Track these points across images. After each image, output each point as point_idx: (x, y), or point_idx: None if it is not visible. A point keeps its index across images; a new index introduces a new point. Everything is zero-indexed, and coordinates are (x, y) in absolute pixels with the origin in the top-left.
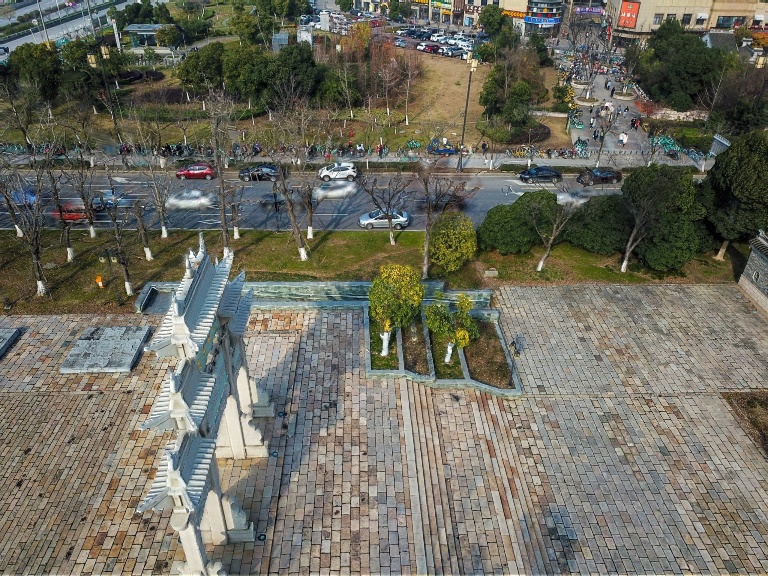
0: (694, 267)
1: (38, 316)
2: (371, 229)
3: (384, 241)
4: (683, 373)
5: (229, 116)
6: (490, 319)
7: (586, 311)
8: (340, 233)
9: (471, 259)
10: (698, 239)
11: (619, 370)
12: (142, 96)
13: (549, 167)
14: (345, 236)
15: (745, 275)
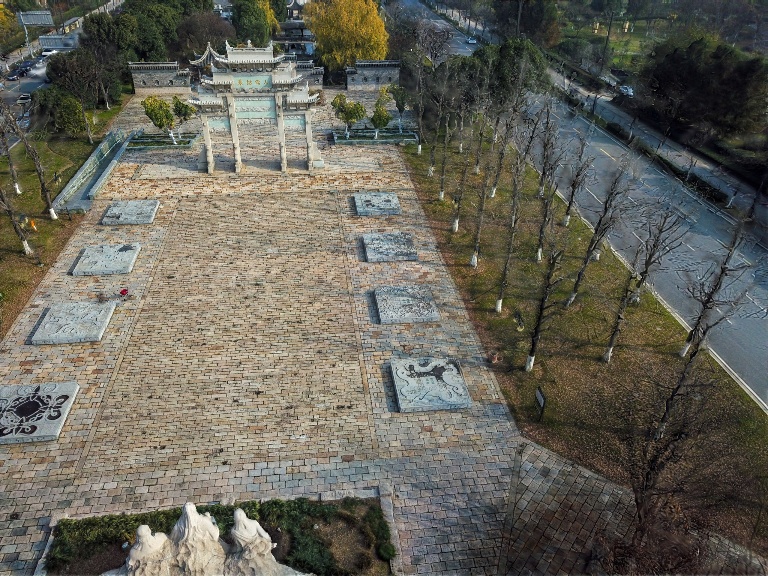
0: None
1: (65, 249)
2: None
3: None
4: None
5: None
6: (144, 132)
7: None
8: None
9: None
10: None
11: None
12: None
13: None
14: (0, 168)
15: (137, 87)
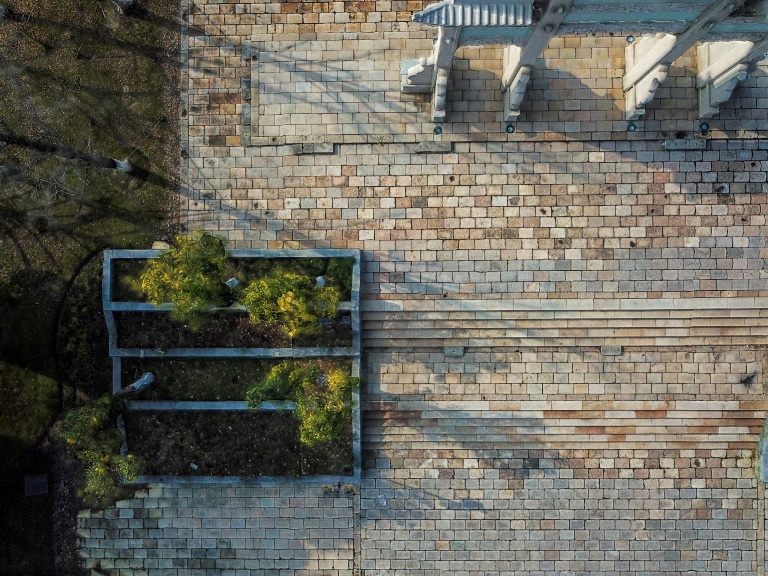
0: None
1: None
2: None
3: None
4: None
5: None
6: None
7: None
8: None
9: None
10: None
11: None
12: None
13: None
14: None
15: None
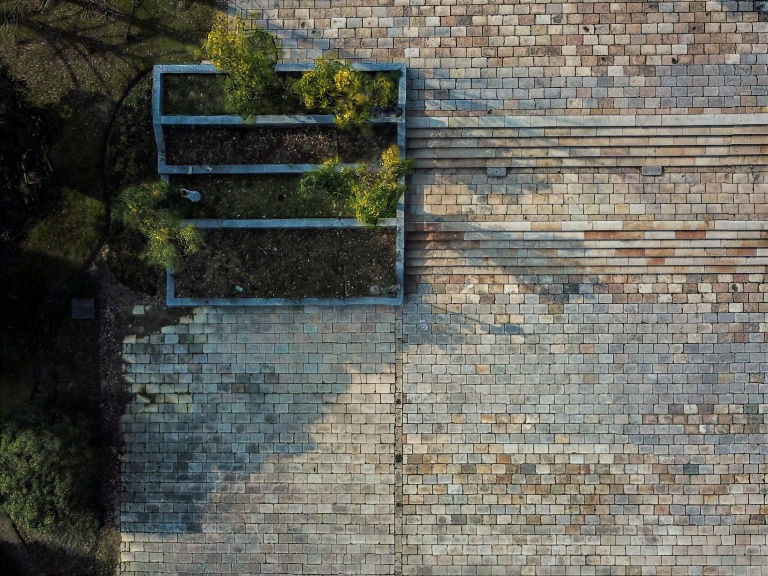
0: None
1: None
2: None
3: None
4: None
5: None
6: None
7: None
8: None
9: None
10: None
11: None
12: None
13: None
14: None
15: None
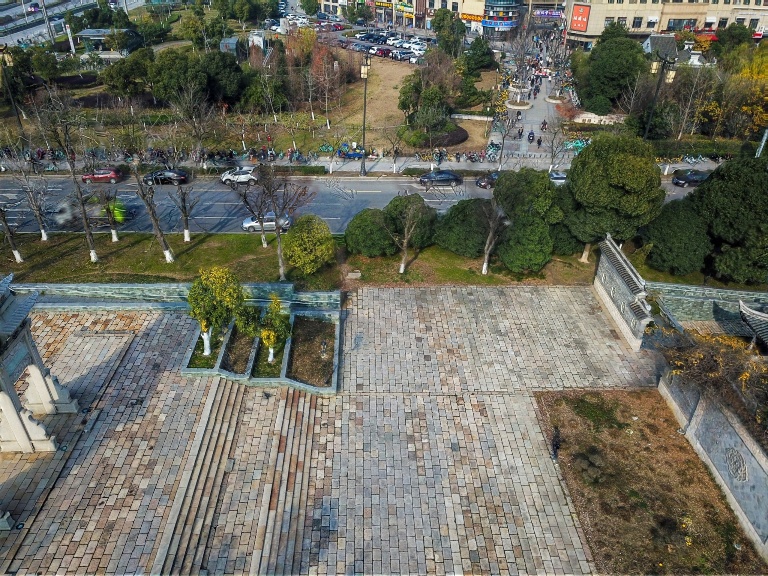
0: (556, 269)
1: None
2: (252, 232)
3: (258, 244)
4: (504, 372)
5: (99, 123)
6: (331, 320)
7: (434, 312)
8: (220, 236)
9: (331, 261)
10: (552, 242)
11: (443, 369)
12: (45, 102)
13: (451, 171)
14: (223, 239)
15: (598, 277)
